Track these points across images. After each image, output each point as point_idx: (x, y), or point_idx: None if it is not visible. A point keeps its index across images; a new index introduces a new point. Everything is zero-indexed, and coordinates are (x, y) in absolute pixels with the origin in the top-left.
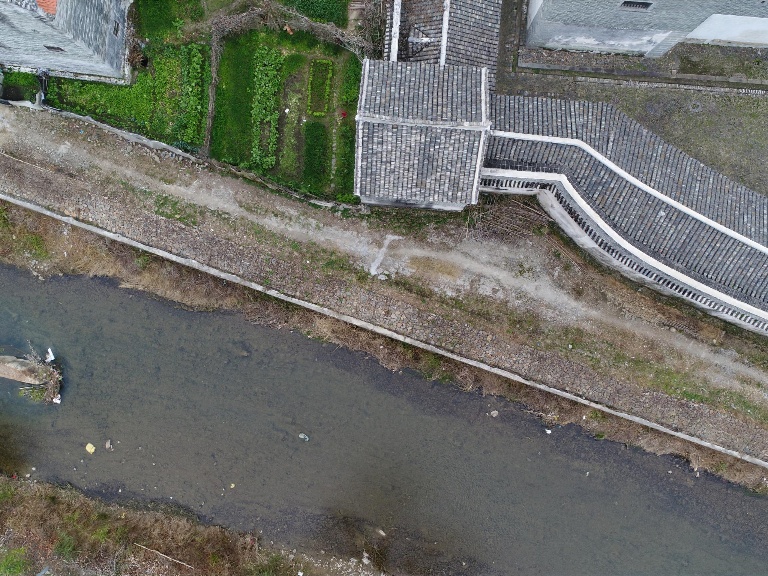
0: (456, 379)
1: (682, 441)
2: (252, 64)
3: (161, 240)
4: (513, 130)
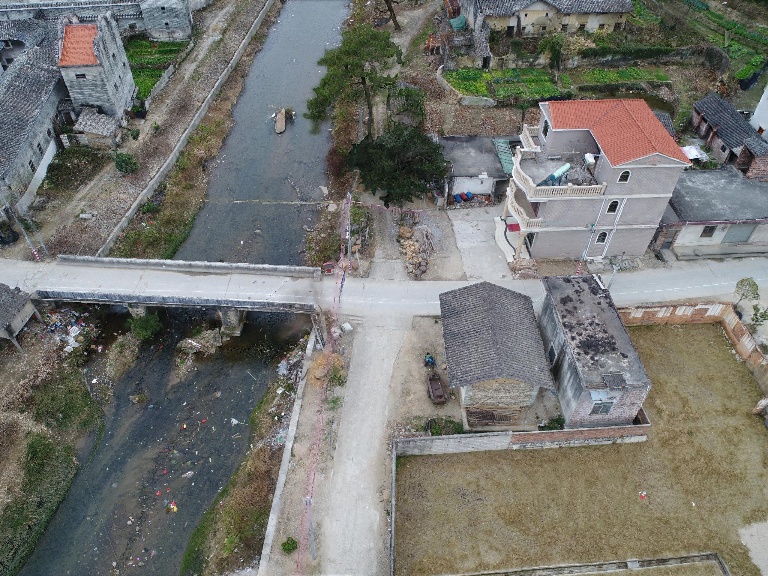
0: (262, 35)
1: (275, 0)
2: None
3: None
4: None
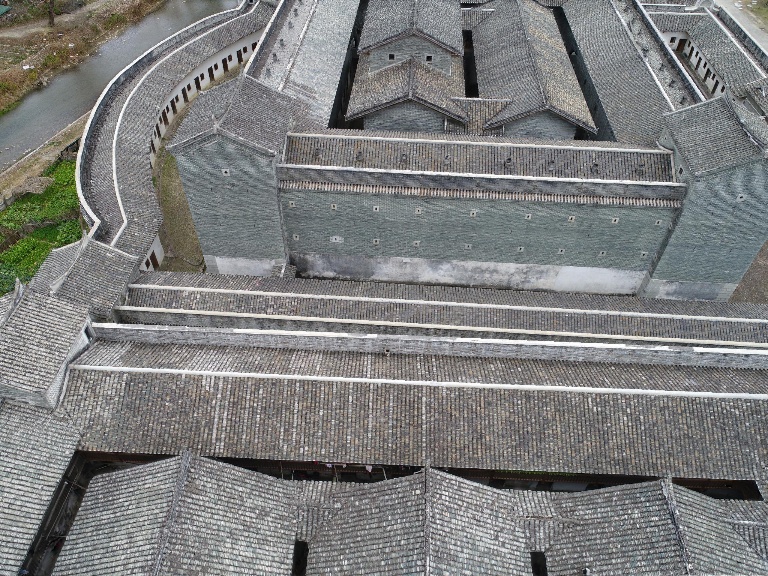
0: None
1: None
2: None
3: None
4: (259, 5)
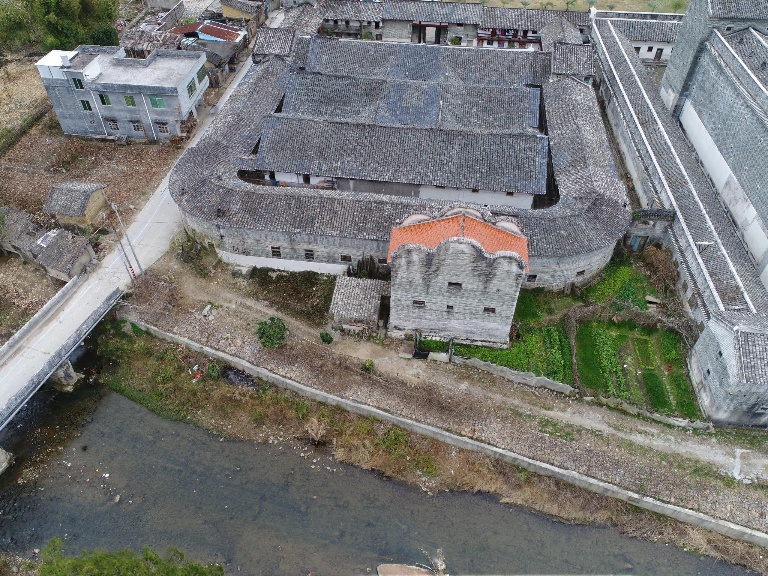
0: None
1: None
2: (592, 339)
3: (545, 454)
4: None
